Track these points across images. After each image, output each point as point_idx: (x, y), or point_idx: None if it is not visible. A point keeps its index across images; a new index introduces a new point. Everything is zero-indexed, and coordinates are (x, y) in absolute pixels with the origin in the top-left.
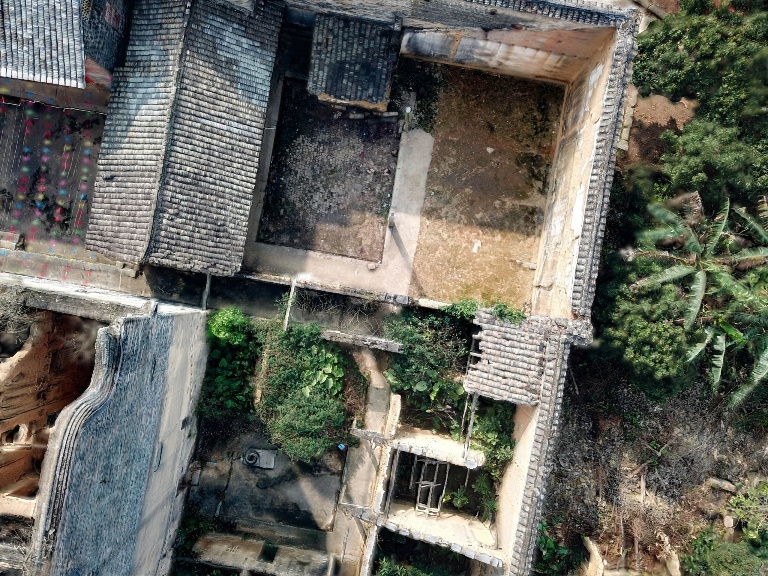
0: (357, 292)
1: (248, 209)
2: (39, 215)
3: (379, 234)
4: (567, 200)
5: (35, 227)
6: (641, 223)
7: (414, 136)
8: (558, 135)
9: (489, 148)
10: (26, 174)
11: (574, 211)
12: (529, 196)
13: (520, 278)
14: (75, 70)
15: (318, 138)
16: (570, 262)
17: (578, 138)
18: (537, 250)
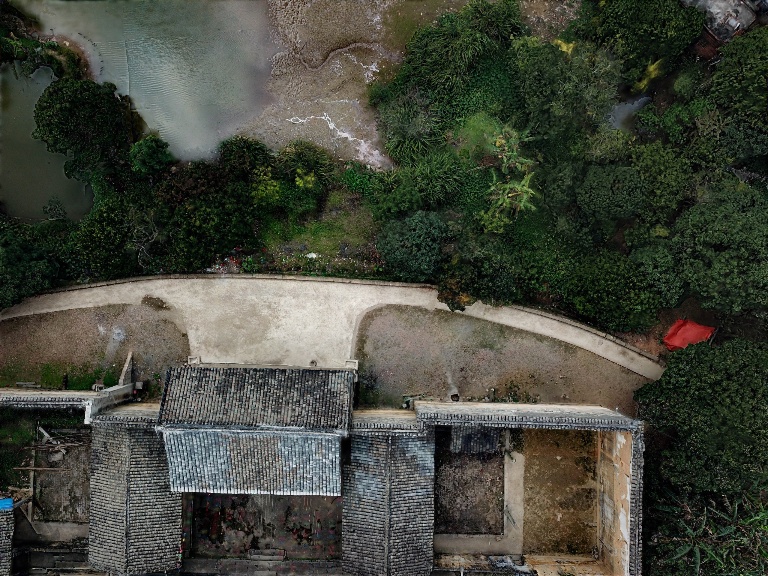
0: (500, 570)
1: (432, 535)
2: (293, 535)
3: (499, 517)
4: (613, 503)
5: (291, 543)
6: (656, 498)
7: (512, 456)
8: (598, 444)
9: (558, 457)
10: (281, 511)
11: (620, 519)
12: (586, 483)
13: (588, 533)
14: (336, 488)
15: (454, 464)
16: (623, 553)
17: (615, 467)
18: (596, 514)
